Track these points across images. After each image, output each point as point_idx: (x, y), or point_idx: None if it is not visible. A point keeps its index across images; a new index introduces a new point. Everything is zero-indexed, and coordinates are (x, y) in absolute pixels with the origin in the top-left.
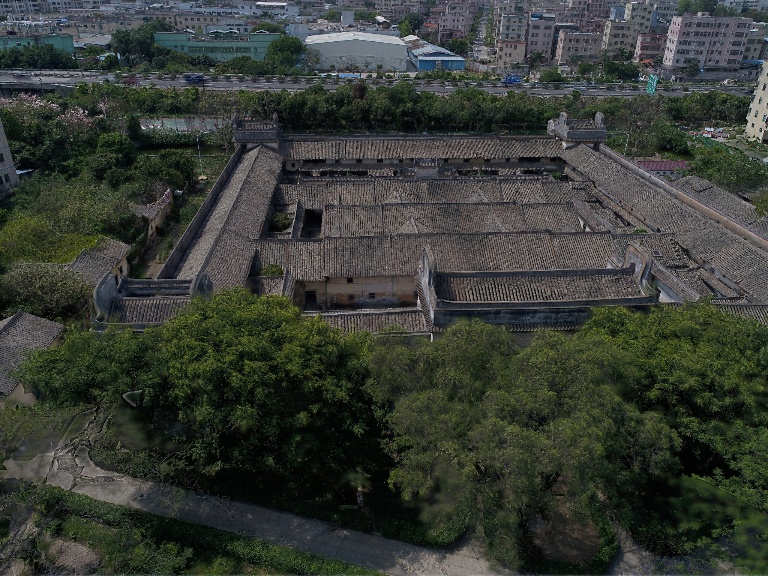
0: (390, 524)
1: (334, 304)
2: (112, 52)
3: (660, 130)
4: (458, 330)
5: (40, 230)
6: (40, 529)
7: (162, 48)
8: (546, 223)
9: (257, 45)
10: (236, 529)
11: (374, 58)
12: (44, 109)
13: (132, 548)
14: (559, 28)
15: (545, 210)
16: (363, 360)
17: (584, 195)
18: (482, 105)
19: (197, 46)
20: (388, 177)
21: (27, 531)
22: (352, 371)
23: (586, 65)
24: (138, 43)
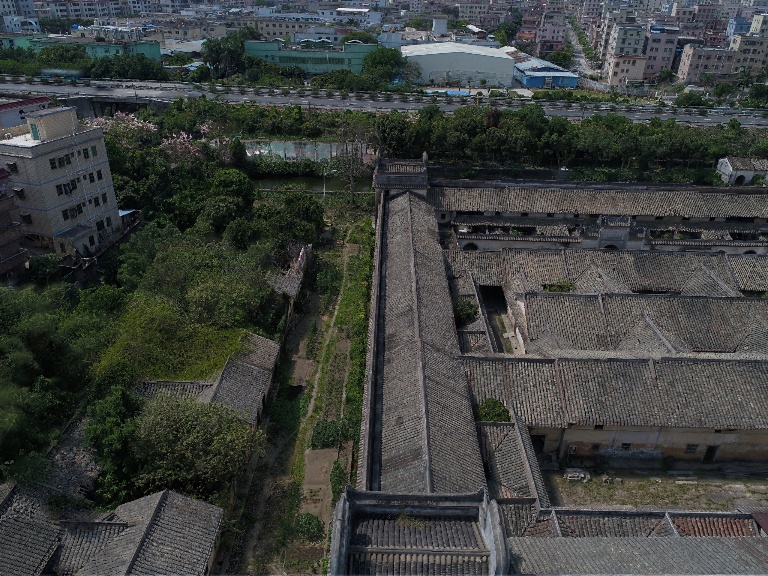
0: None
1: (570, 455)
2: (201, 61)
3: None
4: None
5: (168, 323)
6: None
7: (253, 58)
8: None
9: (352, 56)
10: None
11: (485, 74)
12: (142, 131)
13: None
14: (684, 42)
15: None
16: None
17: None
18: (639, 138)
19: (288, 56)
20: (564, 237)
21: None
22: None
23: (725, 86)
24: (229, 52)
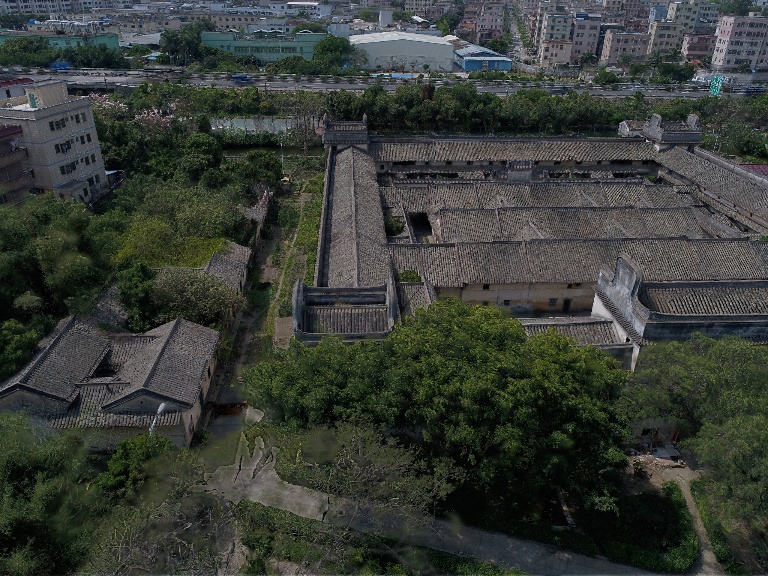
0: (618, 548)
1: None
2: (160, 52)
3: (735, 132)
4: (736, 348)
5: (164, 233)
6: (251, 547)
7: (209, 48)
8: (667, 228)
9: (303, 45)
10: (451, 550)
11: (425, 58)
12: (115, 109)
13: (357, 570)
14: (605, 28)
15: (664, 215)
16: (608, 377)
17: (690, 199)
18: (552, 106)
19: (243, 46)
20: (480, 180)
21: (236, 549)
22: (599, 388)
23: (638, 66)
24: (187, 43)
